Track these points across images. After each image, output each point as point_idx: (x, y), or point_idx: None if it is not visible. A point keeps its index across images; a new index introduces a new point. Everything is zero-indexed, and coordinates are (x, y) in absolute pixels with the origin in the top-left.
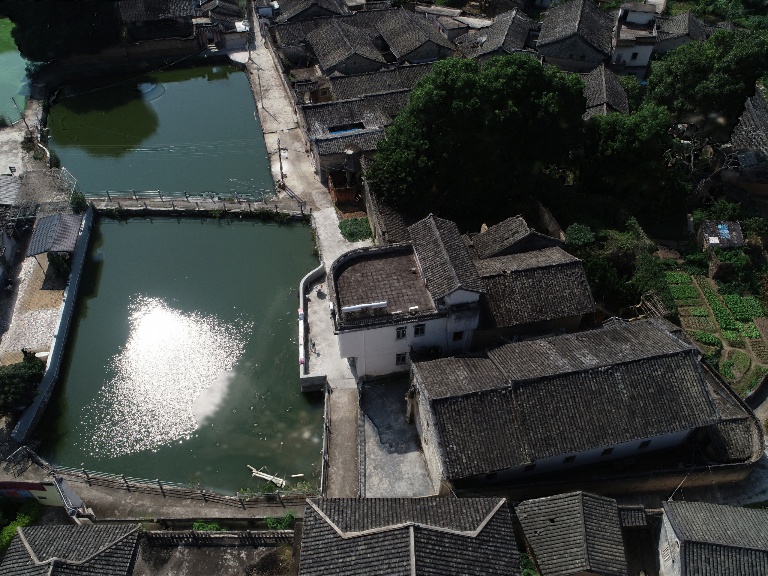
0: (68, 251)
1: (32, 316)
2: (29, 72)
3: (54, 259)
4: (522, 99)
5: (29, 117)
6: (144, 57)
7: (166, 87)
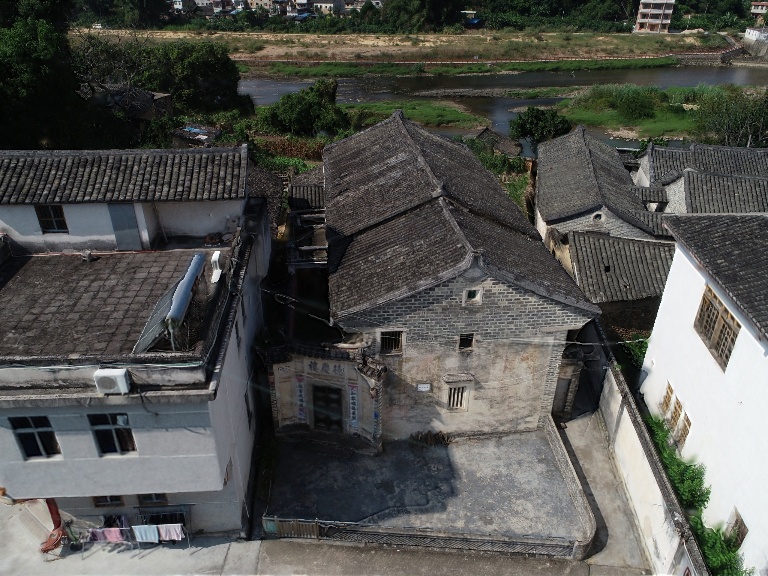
0: None
1: None
2: None
3: None
4: None
5: None
6: None
7: None
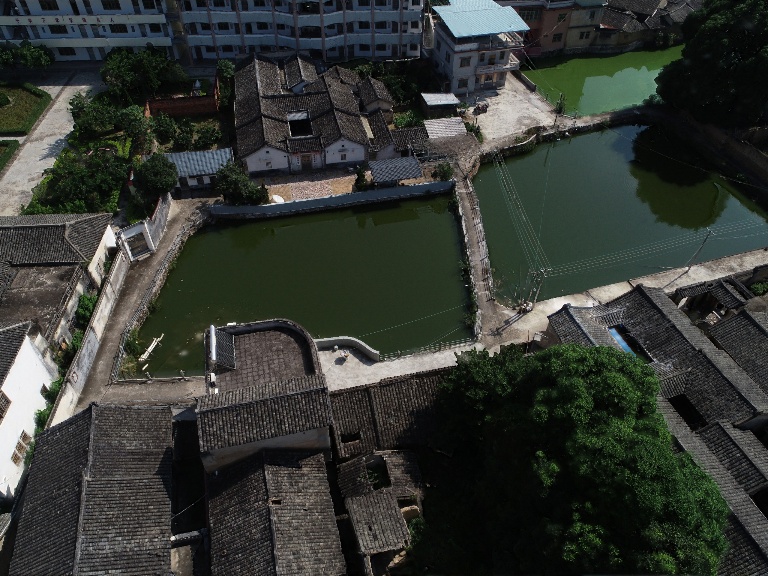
0: (374, 179)
1: (324, 188)
2: (650, 99)
3: (359, 173)
4: (583, 494)
5: (579, 120)
6: (737, 158)
7: (731, 199)
